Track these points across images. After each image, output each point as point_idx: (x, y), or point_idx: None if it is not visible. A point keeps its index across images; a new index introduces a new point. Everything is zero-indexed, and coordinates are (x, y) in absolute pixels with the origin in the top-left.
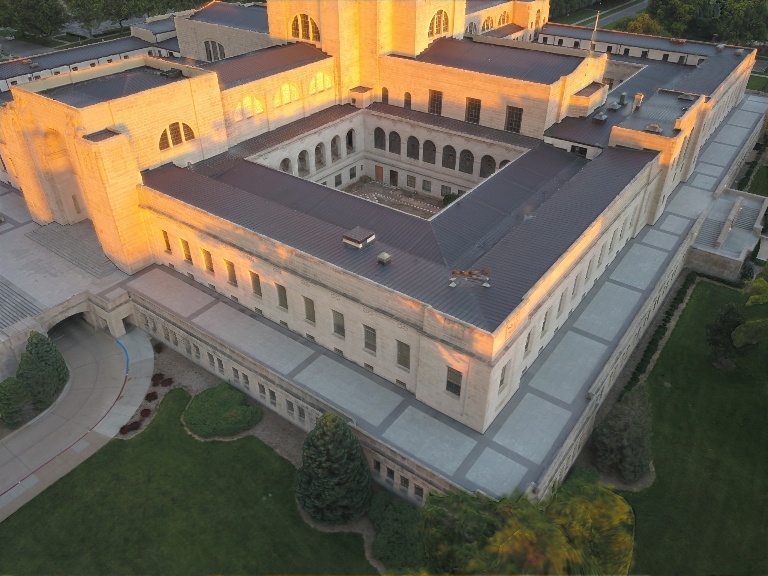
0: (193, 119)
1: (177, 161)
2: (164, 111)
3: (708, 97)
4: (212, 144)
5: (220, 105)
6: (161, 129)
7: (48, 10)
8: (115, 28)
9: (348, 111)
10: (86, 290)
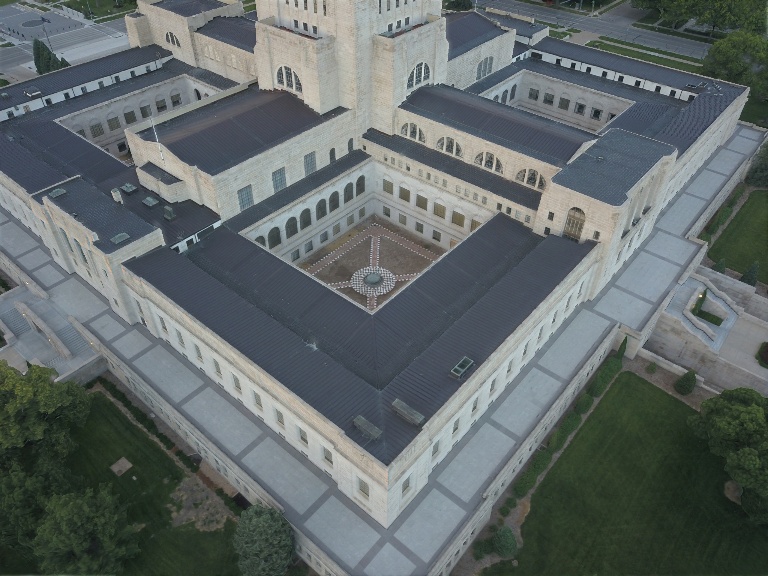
0: None
1: (174, 53)
2: (166, 23)
3: (110, 253)
4: (188, 57)
5: (190, 38)
6: (166, 31)
7: None
8: None
9: None
10: None
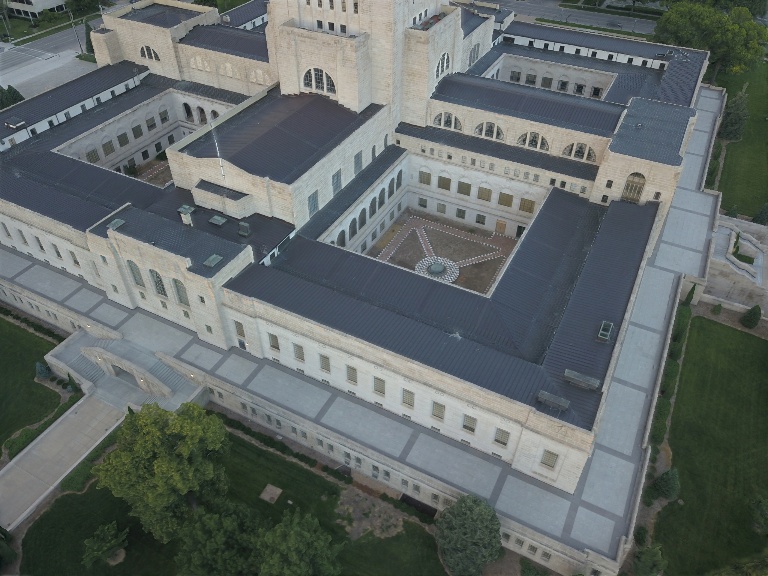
0: (158, 50)
1: (151, 68)
2: (141, 36)
3: (212, 277)
4: (170, 71)
5: (173, 50)
6: (141, 45)
7: None
8: (644, 6)
9: None
10: None
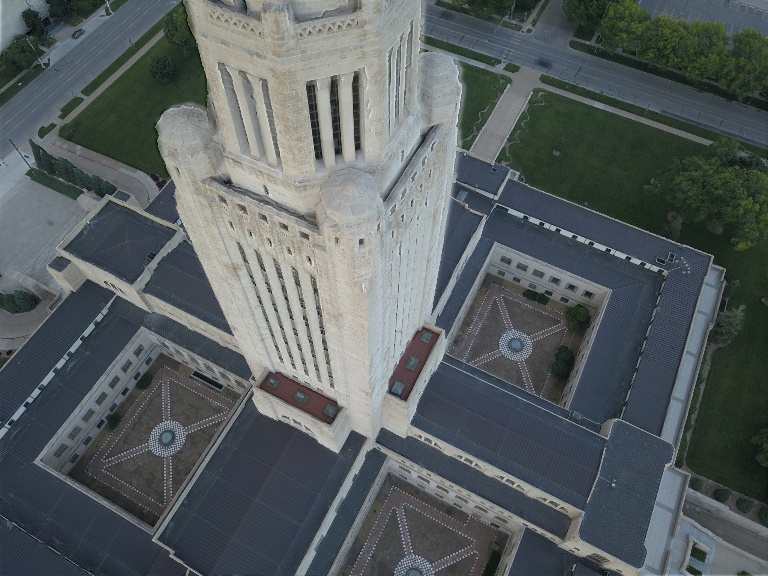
0: (123, 290)
1: None
2: None
3: None
4: None
5: (140, 298)
6: None
7: (593, 8)
8: None
9: (248, 373)
10: (59, 293)
